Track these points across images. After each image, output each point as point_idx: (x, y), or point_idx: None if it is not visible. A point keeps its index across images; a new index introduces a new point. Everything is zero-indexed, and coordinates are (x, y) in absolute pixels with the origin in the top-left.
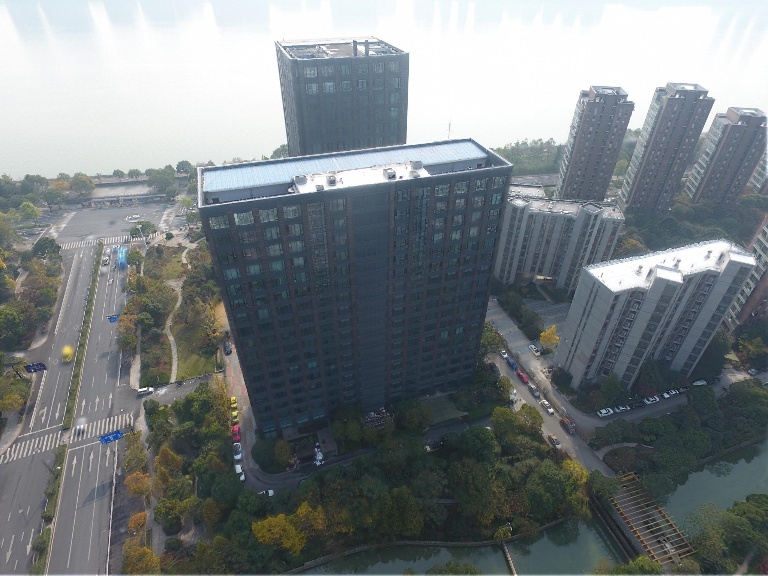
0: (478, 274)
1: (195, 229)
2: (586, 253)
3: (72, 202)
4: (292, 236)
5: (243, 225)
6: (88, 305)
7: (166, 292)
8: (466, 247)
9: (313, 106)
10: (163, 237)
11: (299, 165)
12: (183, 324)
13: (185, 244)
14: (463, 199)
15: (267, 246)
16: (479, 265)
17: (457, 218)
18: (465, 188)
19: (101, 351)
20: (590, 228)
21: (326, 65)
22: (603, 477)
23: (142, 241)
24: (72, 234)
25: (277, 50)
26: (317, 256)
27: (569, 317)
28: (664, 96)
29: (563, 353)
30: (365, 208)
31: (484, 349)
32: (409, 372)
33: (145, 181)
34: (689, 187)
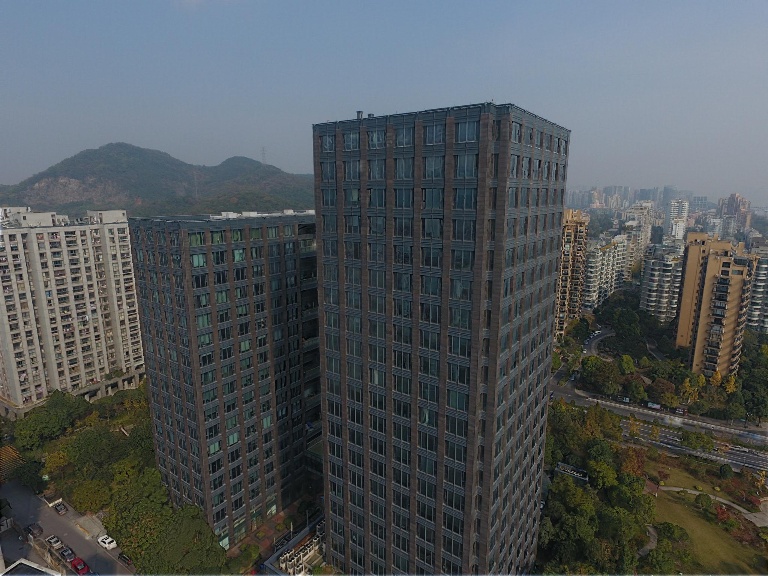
0: None
1: None
2: None
3: None
4: None
5: None
6: None
7: None
8: None
9: None
10: None
11: None
12: None
13: None
14: None
15: None
16: None
17: None
18: None
19: None
20: None
21: None
22: (25, 473)
23: None
24: None
25: None
26: None
27: None
28: None
29: None
30: None
31: None
32: None
33: None
34: None
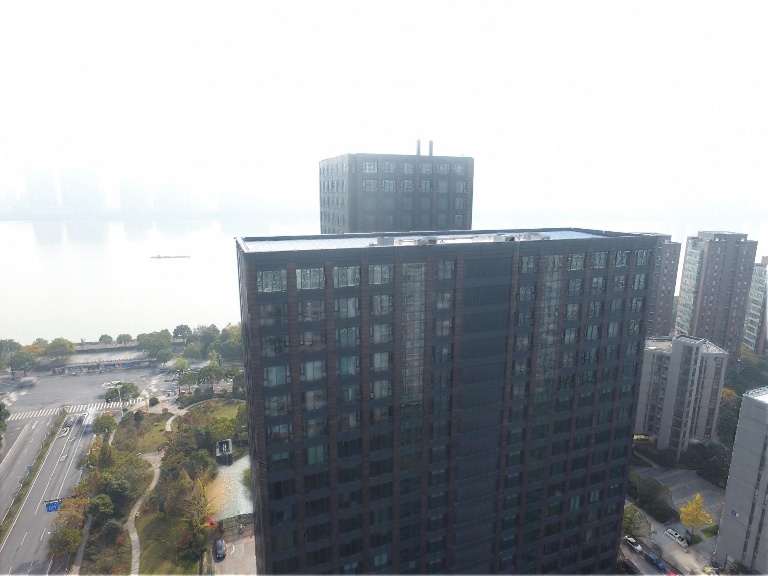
0: (618, 398)
1: (187, 394)
2: (691, 398)
3: (42, 369)
4: (376, 315)
5: (308, 289)
6: (22, 490)
7: (139, 466)
8: (603, 353)
9: (370, 205)
10: (146, 401)
11: (372, 239)
12: (156, 513)
13: (172, 410)
14: (601, 278)
15: (338, 329)
16: (620, 383)
17: (593, 306)
18: (603, 262)
19: (19, 561)
20: (693, 364)
21: (387, 161)
22: None
23: (118, 408)
24: (30, 402)
25: (322, 167)
26: (408, 352)
27: (733, 475)
28: (701, 242)
29: (734, 537)
30: (480, 278)
31: (622, 532)
32: (524, 575)
33: (135, 347)
34: (745, 339)
